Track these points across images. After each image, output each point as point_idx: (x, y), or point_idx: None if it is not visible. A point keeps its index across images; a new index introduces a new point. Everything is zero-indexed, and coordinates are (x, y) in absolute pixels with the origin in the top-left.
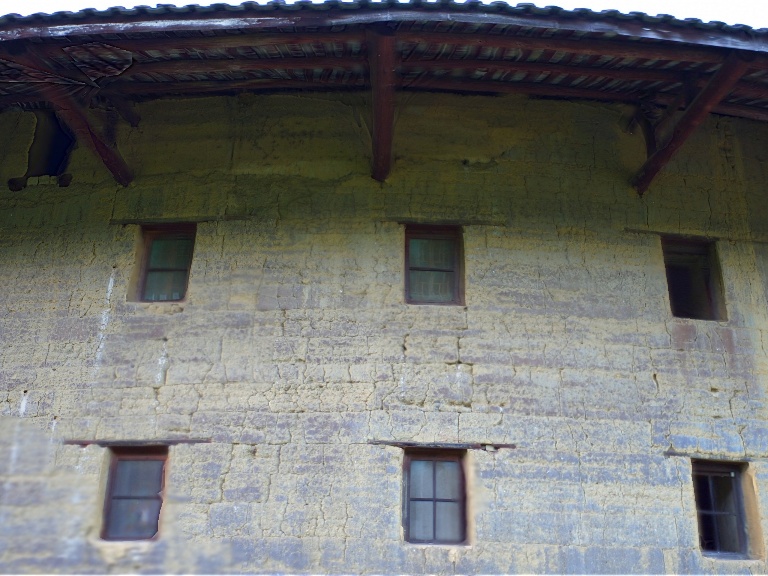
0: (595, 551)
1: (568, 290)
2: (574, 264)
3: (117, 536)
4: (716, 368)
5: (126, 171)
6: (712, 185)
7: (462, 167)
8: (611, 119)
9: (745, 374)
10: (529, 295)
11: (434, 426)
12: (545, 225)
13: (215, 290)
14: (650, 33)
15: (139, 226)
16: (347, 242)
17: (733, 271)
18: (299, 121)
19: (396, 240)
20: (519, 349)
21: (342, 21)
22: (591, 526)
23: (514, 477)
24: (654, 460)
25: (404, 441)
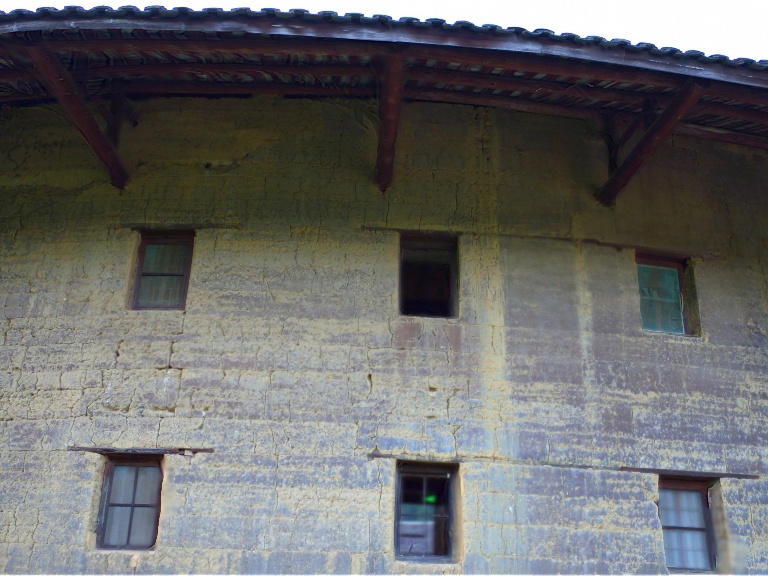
0: (280, 556)
1: (291, 291)
2: (302, 264)
3: None
4: (437, 367)
5: None
6: (462, 178)
7: (203, 170)
8: (349, 115)
9: (468, 372)
10: (250, 297)
11: (134, 431)
12: (278, 226)
13: None
14: (280, 29)
15: None
16: (79, 250)
17: (472, 266)
18: (51, 131)
19: (126, 246)
20: (232, 352)
21: None
22: (279, 530)
23: (207, 481)
24: (356, 462)
25: (103, 447)
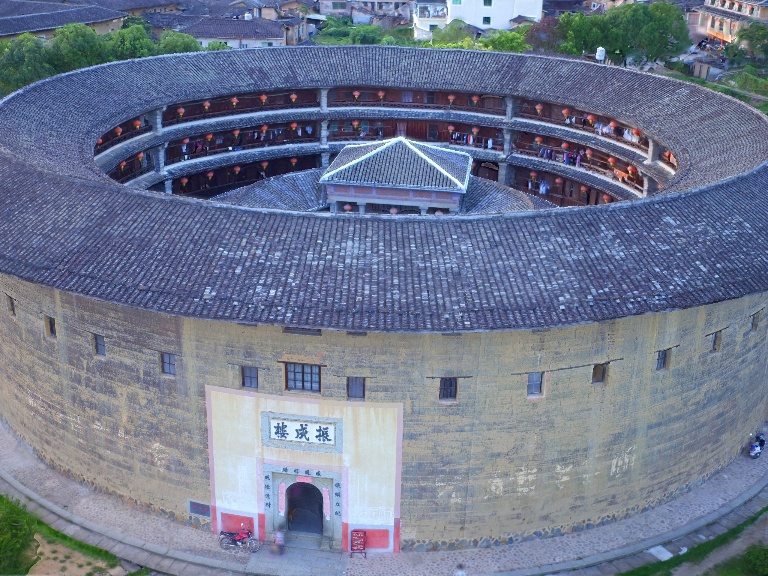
0: None
1: None
2: None
3: None
4: None
5: None
6: None
7: None
8: None
9: (53, 297)
10: None
11: None
12: None
13: None
14: None
15: None
16: None
17: None
18: None
19: None
20: None
21: None
22: None
23: None
24: None
25: None
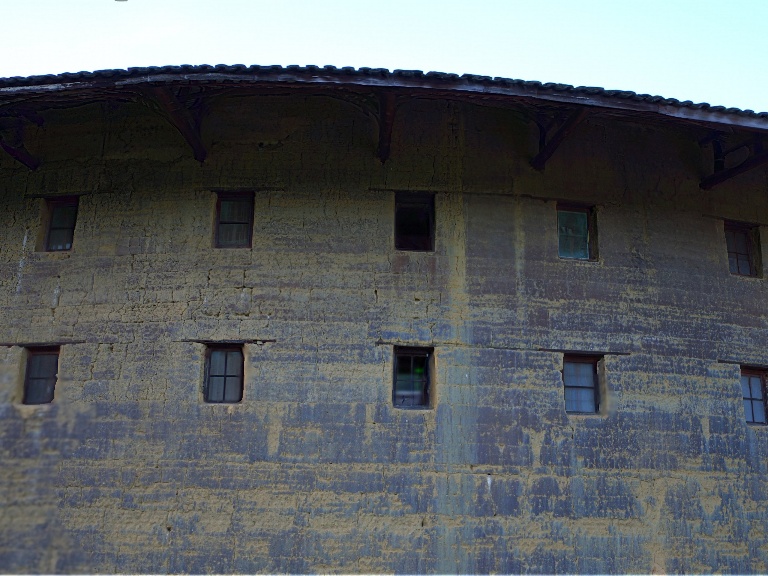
0: (321, 406)
1: (323, 234)
2: (329, 216)
3: (33, 402)
4: (420, 285)
5: (32, 161)
6: (438, 152)
7: (258, 148)
8: (359, 110)
9: (441, 288)
10: (295, 239)
11: (224, 329)
12: (312, 188)
13: (90, 243)
14: (318, 79)
15: (43, 199)
16: (176, 206)
17: (444, 215)
18: (148, 119)
19: (208, 204)
20: (285, 277)
21: (121, 83)
22: (320, 390)
23: (273, 361)
24: (368, 347)
25: (205, 339)
